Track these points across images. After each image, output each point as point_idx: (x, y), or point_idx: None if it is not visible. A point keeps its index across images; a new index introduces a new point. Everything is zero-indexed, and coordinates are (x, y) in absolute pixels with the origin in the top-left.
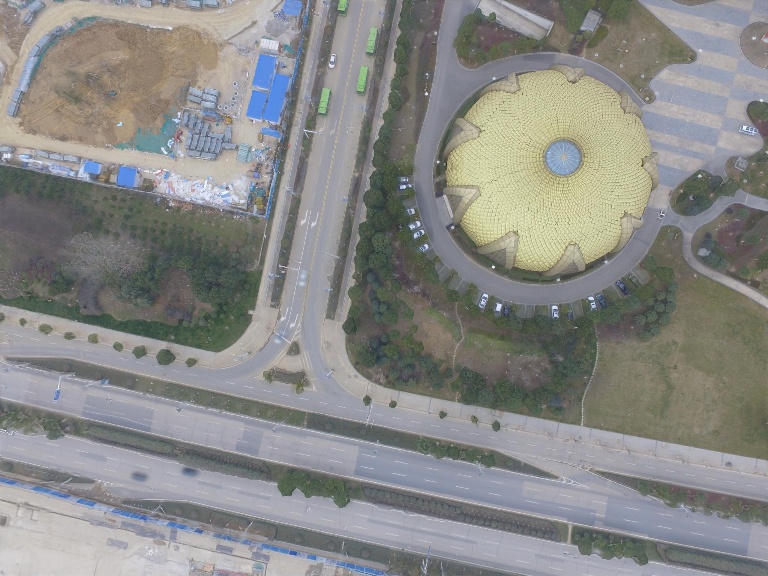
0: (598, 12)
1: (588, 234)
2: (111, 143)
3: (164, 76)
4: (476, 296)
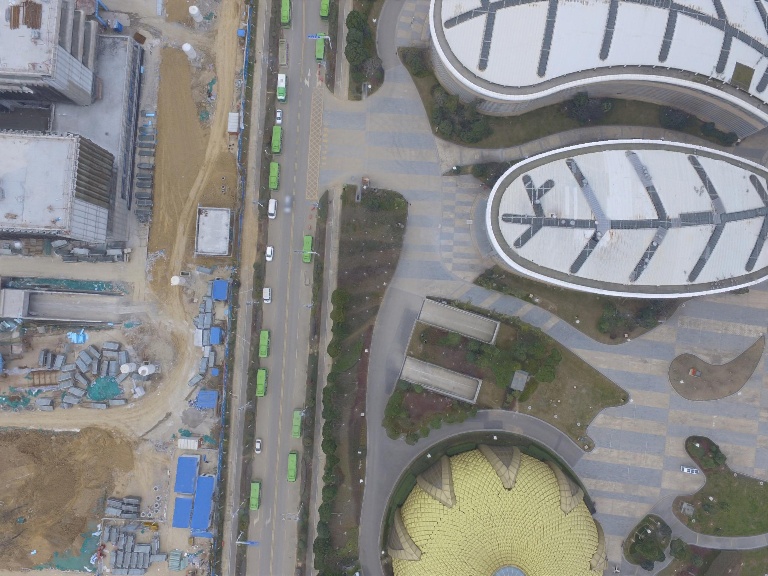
0: (525, 371)
1: None
2: (27, 566)
3: (77, 490)
4: None
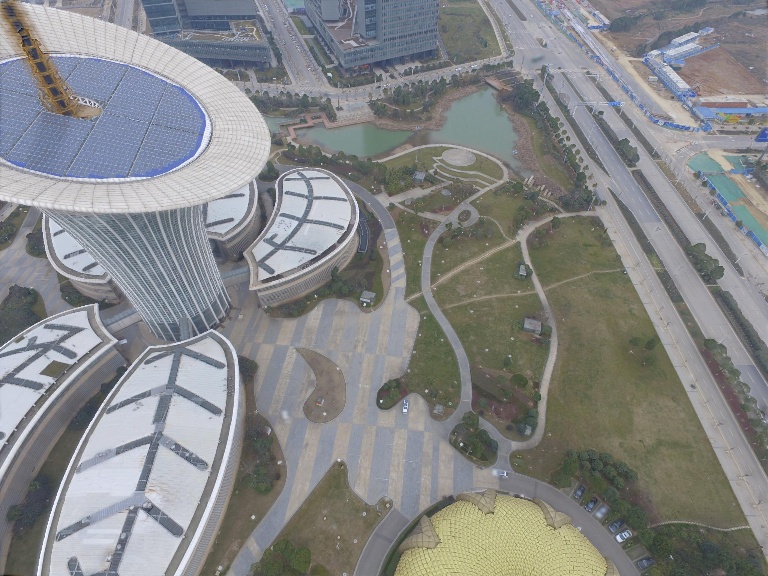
0: None
1: (589, 568)
2: None
3: None
4: None
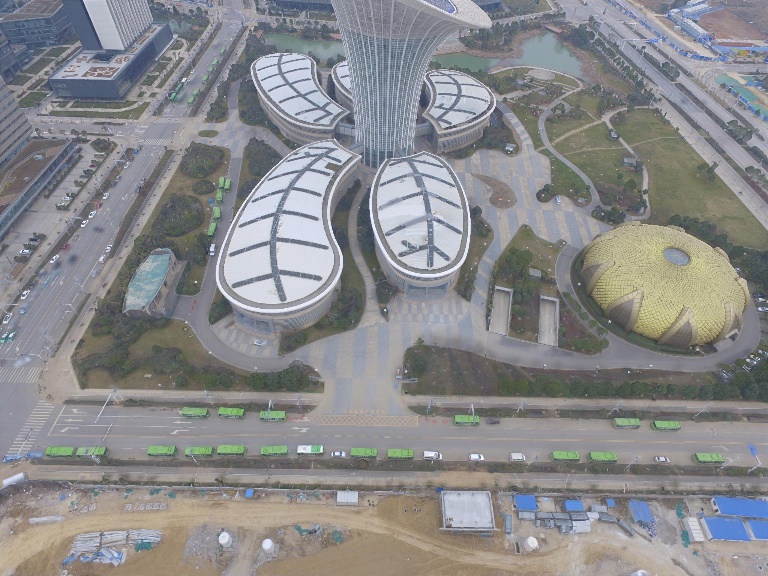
0: None
1: None
2: None
3: None
4: (764, 316)
